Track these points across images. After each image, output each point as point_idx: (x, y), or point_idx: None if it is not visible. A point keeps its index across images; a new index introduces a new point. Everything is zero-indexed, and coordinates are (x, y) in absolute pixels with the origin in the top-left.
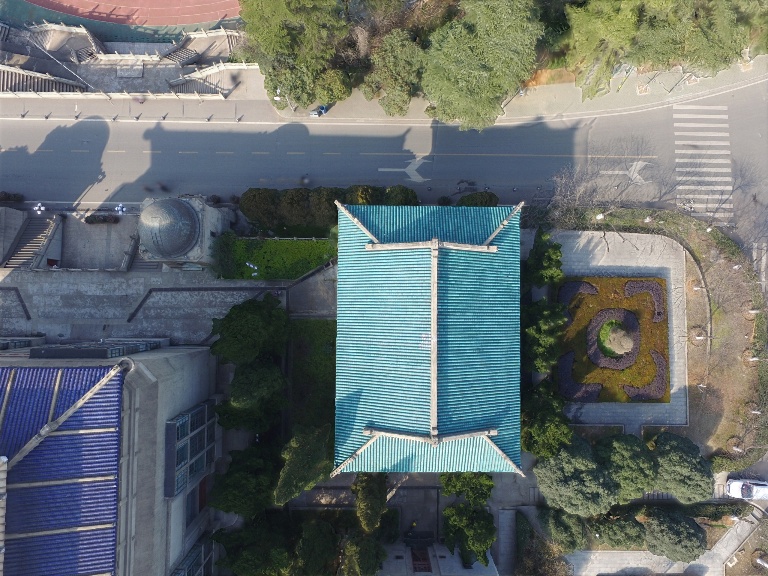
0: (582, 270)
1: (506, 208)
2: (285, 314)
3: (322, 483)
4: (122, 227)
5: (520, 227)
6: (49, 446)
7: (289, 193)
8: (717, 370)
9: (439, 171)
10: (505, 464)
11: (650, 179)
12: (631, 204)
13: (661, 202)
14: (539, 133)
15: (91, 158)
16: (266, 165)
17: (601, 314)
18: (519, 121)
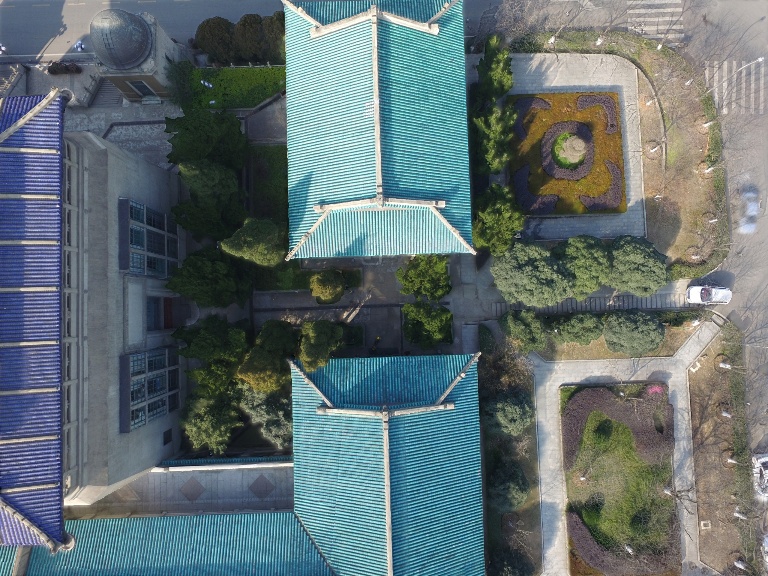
0: (536, 91)
1: None
2: None
3: (286, 305)
4: (85, 77)
5: (473, 53)
6: None
7: (242, 17)
8: (673, 184)
9: None
10: (456, 243)
11: (601, 5)
12: (583, 29)
13: (612, 26)
14: None
15: (52, 12)
16: (223, 10)
17: (554, 127)
18: None
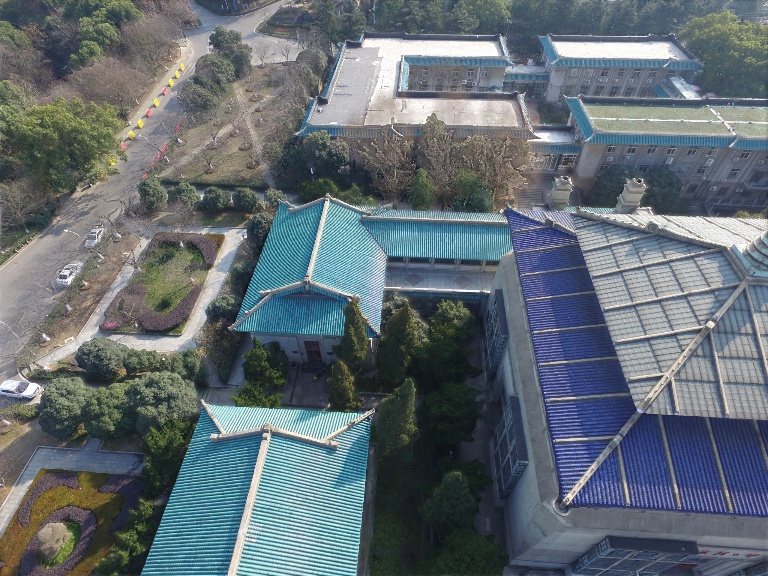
0: None
1: None
2: None
3: None
4: None
5: None
6: (612, 427)
7: None
8: None
9: None
10: (215, 411)
11: None
12: None
13: None
14: None
15: None
16: None
17: None
18: None
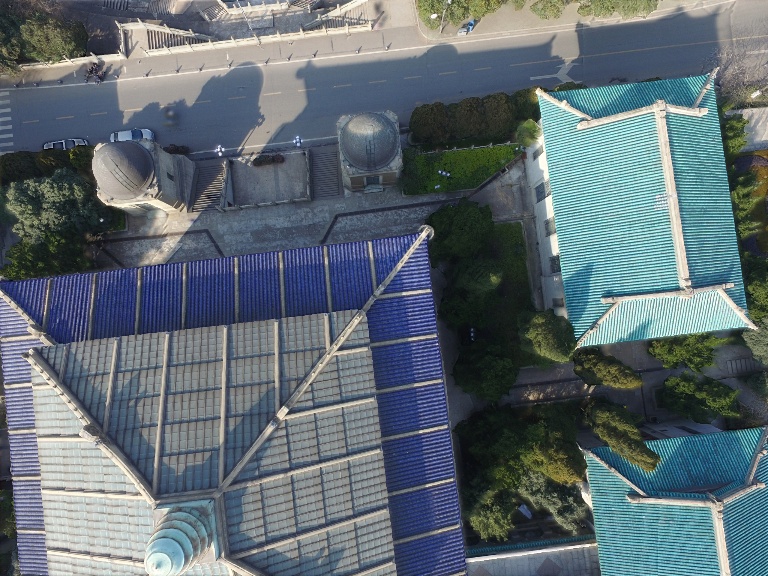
0: (747, 147)
1: (700, 77)
2: (490, 211)
3: (527, 380)
4: (288, 166)
5: None
6: (379, 309)
7: (466, 101)
8: None
9: (590, 72)
10: (736, 319)
11: None
12: None
13: None
14: (682, 23)
15: (249, 103)
16: (420, 88)
17: None
18: (661, 14)
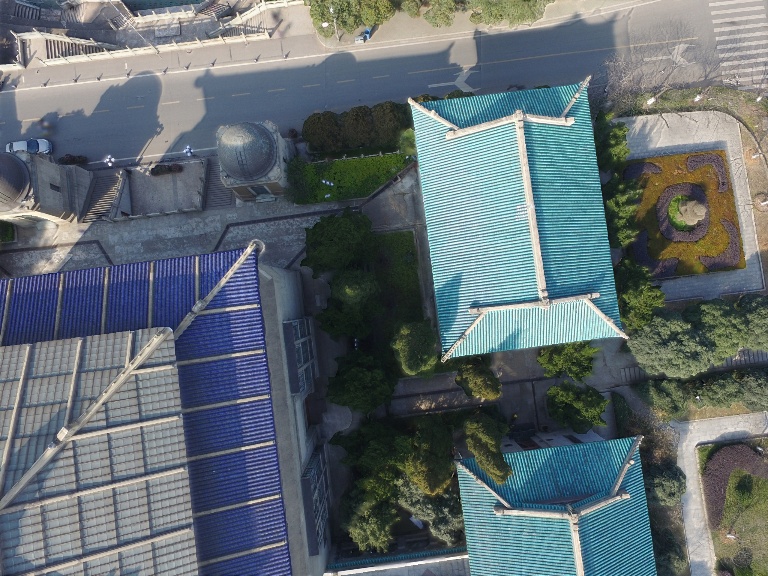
0: (641, 154)
1: (573, 85)
2: (370, 221)
3: (419, 390)
4: (186, 175)
5: None
6: (200, 325)
7: (352, 110)
8: None
9: (488, 80)
10: (607, 329)
11: (694, 60)
12: (679, 86)
13: (707, 81)
14: (580, 30)
15: (147, 113)
16: (318, 97)
17: (668, 190)
18: (559, 21)
